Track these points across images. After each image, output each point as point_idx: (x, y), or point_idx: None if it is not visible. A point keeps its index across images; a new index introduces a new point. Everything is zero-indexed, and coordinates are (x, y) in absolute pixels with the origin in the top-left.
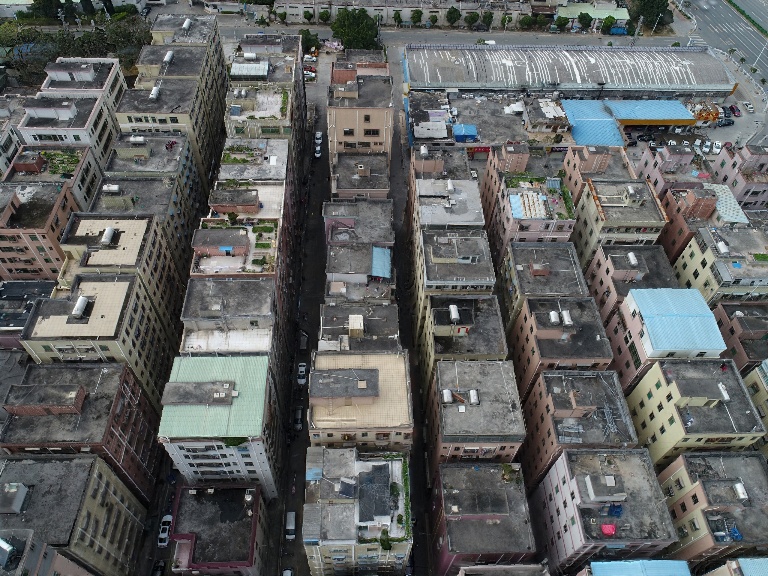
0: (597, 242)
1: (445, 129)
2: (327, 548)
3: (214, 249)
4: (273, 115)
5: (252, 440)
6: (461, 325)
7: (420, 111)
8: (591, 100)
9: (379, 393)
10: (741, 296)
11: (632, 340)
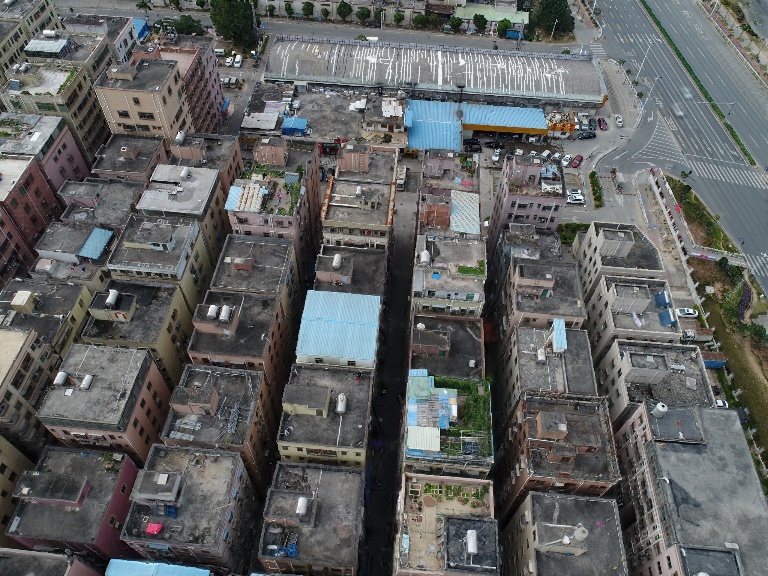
0: (326, 242)
1: (275, 121)
2: None
3: None
4: (50, 92)
5: None
6: (115, 310)
7: (259, 102)
8: (448, 102)
9: None
10: (442, 309)
11: None
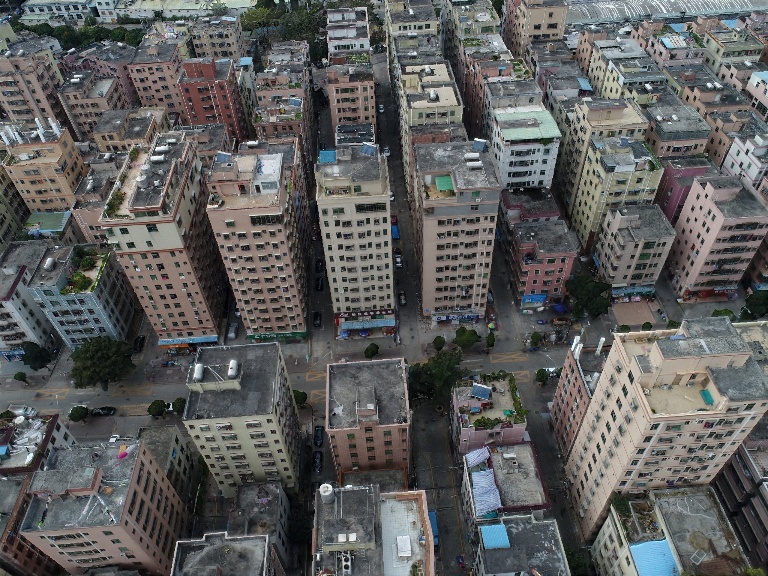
0: (719, 66)
1: None
2: (616, 178)
3: (493, 71)
4: (488, 20)
5: (555, 142)
6: (654, 93)
7: None
8: (677, 24)
9: (622, 115)
10: None
11: (758, 101)
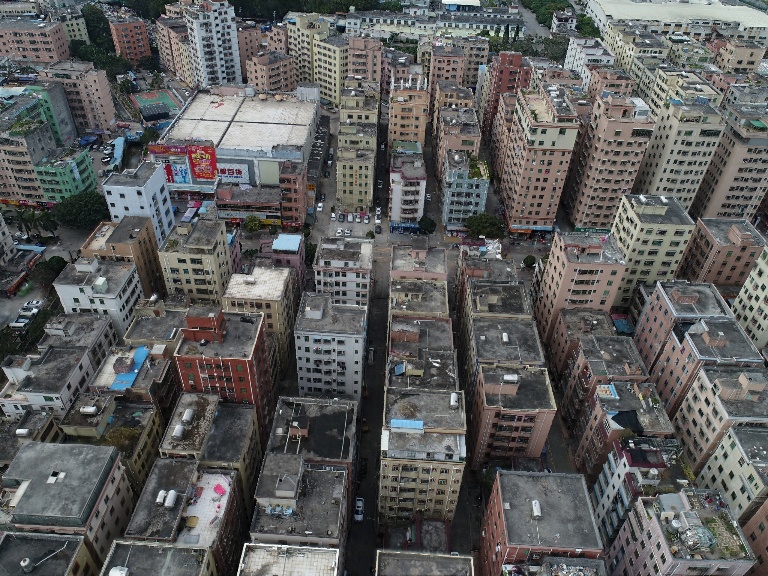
0: None
1: None
2: None
3: (732, 80)
4: None
5: None
6: None
7: None
8: None
9: None
10: None
11: None
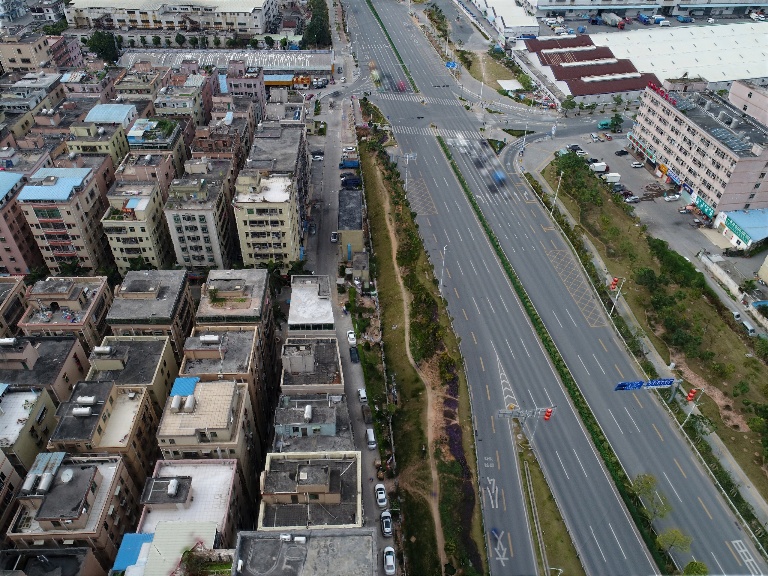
0: None
1: None
2: None
3: None
4: None
5: None
6: None
7: None
8: None
9: None
10: (173, 115)
11: None
